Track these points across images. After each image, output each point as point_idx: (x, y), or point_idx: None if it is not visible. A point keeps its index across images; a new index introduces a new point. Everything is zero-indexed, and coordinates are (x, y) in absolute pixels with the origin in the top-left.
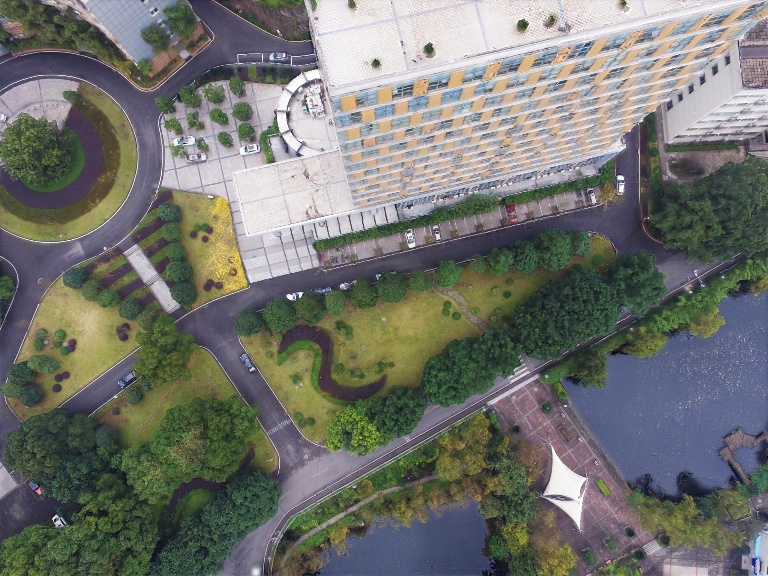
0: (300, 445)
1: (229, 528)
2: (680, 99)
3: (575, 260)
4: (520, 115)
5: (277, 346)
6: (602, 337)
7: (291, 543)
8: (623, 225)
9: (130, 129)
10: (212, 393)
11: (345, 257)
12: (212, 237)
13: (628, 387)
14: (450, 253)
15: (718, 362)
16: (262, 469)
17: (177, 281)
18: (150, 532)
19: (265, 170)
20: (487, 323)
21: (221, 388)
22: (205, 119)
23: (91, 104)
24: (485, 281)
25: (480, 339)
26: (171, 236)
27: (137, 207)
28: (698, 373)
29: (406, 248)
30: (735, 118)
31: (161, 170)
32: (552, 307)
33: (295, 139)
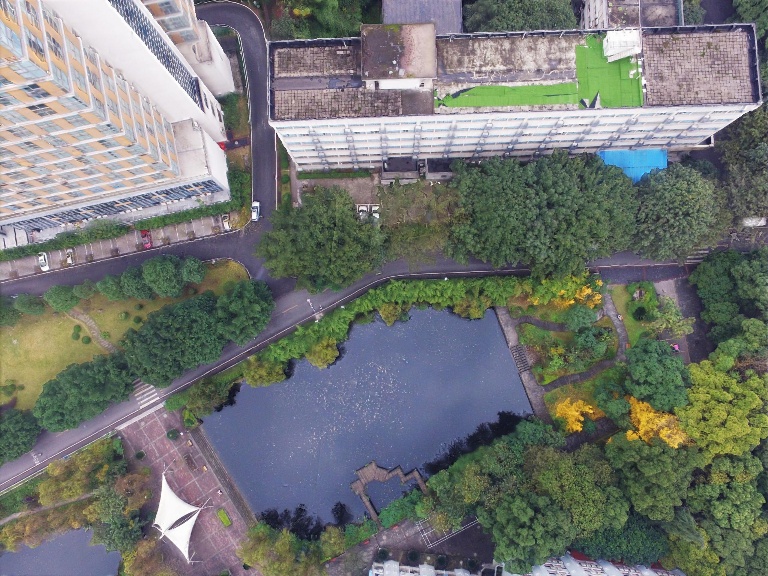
0: None
1: None
2: None
3: (208, 286)
4: None
5: None
6: (231, 364)
7: None
8: None
9: None
10: None
11: None
12: None
13: (264, 416)
14: (84, 277)
15: (357, 393)
16: None
17: None
18: None
19: None
20: (118, 348)
21: None
22: None
23: None
24: (116, 305)
25: (89, 364)
26: None
27: None
28: (335, 403)
29: (40, 271)
30: (321, 148)
31: None
32: (147, 334)
33: None
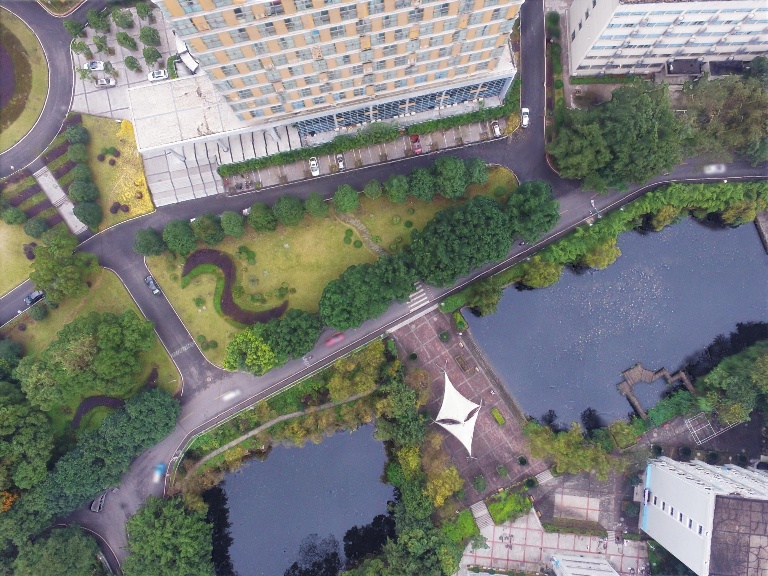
0: (203, 368)
1: (124, 440)
2: (580, 27)
3: (478, 191)
4: (357, 4)
5: (181, 269)
6: (502, 268)
7: (191, 462)
8: (527, 158)
9: (42, 54)
10: (116, 313)
11: (249, 183)
12: (119, 161)
13: (529, 320)
14: (353, 182)
15: (620, 298)
16: (165, 390)
17: (80, 200)
18: (44, 439)
19: (159, 87)
20: (388, 252)
21: (126, 309)
22: (115, 45)
23: (5, 28)
24: (387, 210)
25: (375, 264)
26: (75, 156)
27: (47, 130)
28: (599, 308)
29: (310, 176)
30: (628, 43)
31: (71, 94)
32: (443, 231)
33: (192, 60)
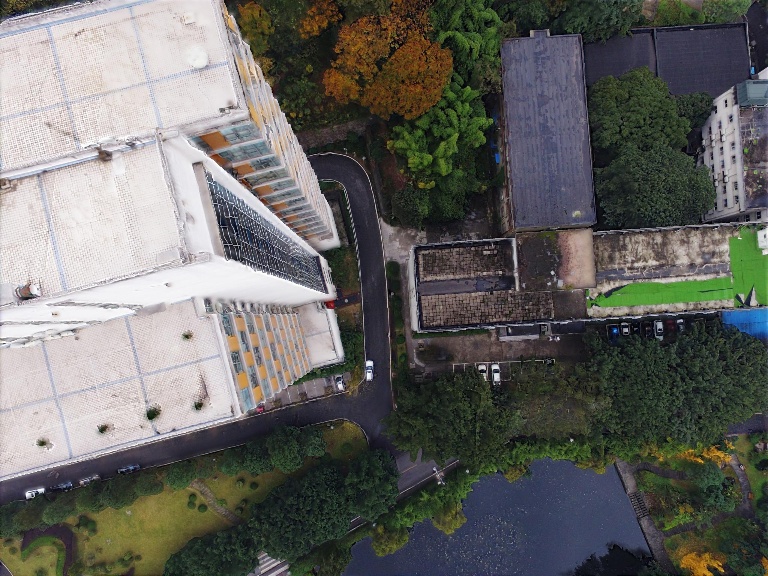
0: None
1: None
2: None
3: None
4: None
5: (20, 542)
6: (352, 527)
7: None
8: (374, 411)
9: None
10: None
11: None
12: None
13: (385, 572)
14: (195, 444)
15: (477, 545)
16: None
17: None
18: None
19: None
20: (235, 514)
21: None
22: None
23: None
24: None
25: (214, 542)
26: None
27: None
28: (456, 557)
29: None
30: None
31: None
32: (277, 517)
33: None
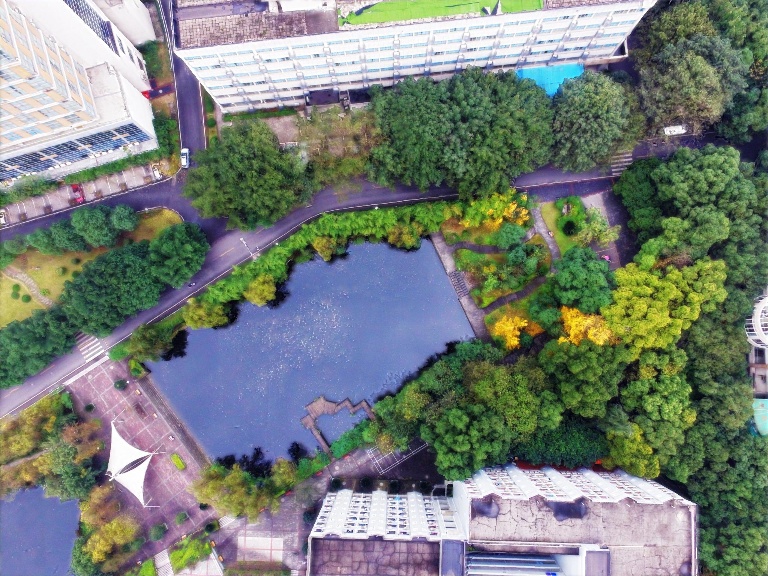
0: None
1: None
2: None
3: (144, 236)
4: None
5: None
6: (172, 311)
7: None
8: None
9: None
10: None
11: None
12: None
13: (211, 360)
14: None
15: (301, 330)
16: None
17: None
18: None
19: None
20: None
21: None
22: None
23: None
24: (54, 262)
25: (28, 319)
26: None
27: None
28: (280, 342)
29: None
30: (237, 82)
31: None
32: (81, 283)
33: None
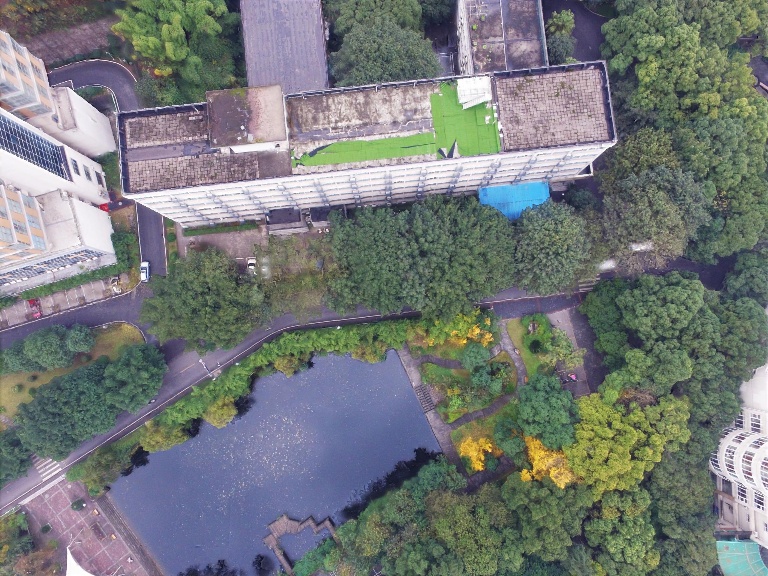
0: None
1: None
2: None
3: (102, 351)
4: None
5: None
6: (131, 429)
7: None
8: None
9: None
10: None
11: None
12: None
13: (172, 477)
14: None
15: (263, 446)
16: None
17: None
18: None
19: None
20: None
21: None
22: None
23: None
24: (10, 379)
25: None
26: None
27: None
28: (242, 459)
29: None
30: (193, 209)
31: None
32: (34, 411)
33: None
